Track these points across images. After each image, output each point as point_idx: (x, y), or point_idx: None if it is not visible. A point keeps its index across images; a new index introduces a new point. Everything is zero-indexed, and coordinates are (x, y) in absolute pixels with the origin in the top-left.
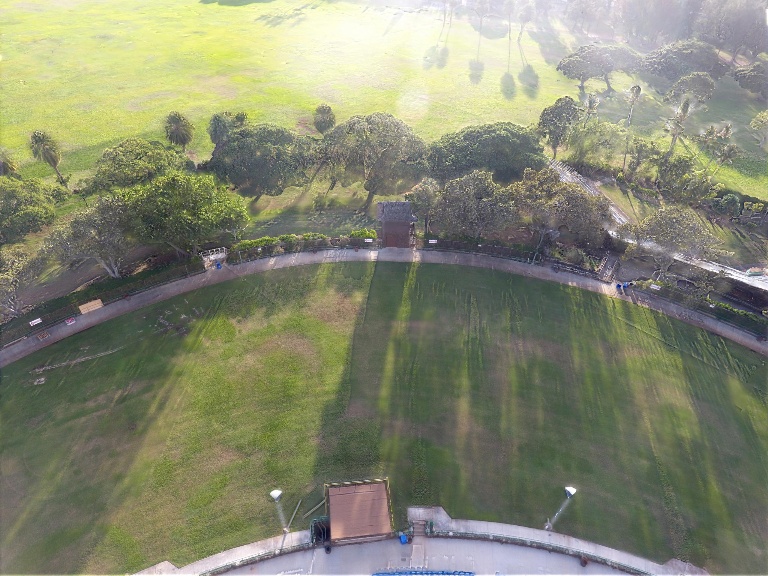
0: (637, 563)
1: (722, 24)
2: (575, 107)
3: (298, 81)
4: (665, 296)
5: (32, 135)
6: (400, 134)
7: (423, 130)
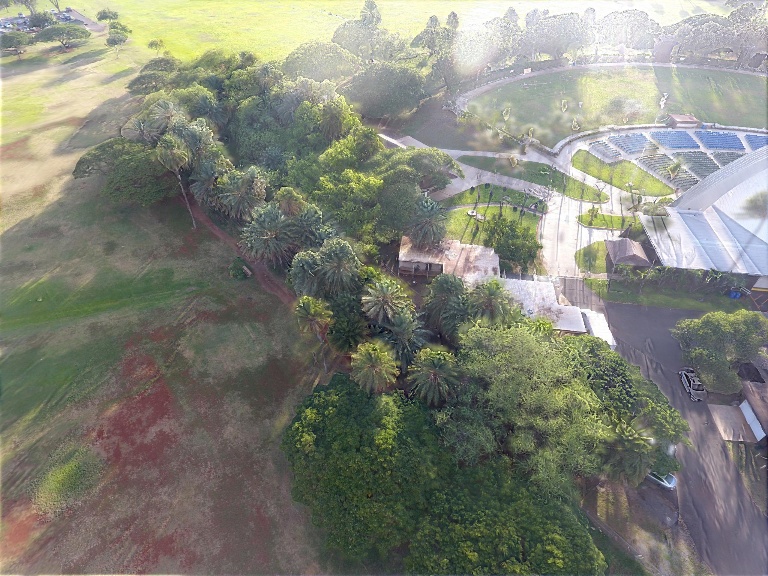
0: None
1: None
2: (755, 8)
3: None
4: None
5: (451, 13)
6: (646, 19)
7: None
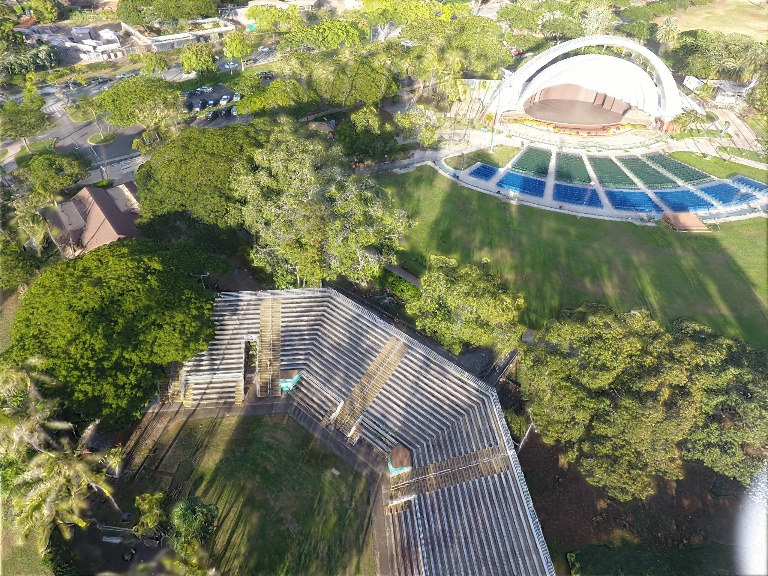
0: (535, 205)
1: None
2: None
3: None
4: None
5: None
6: None
7: None
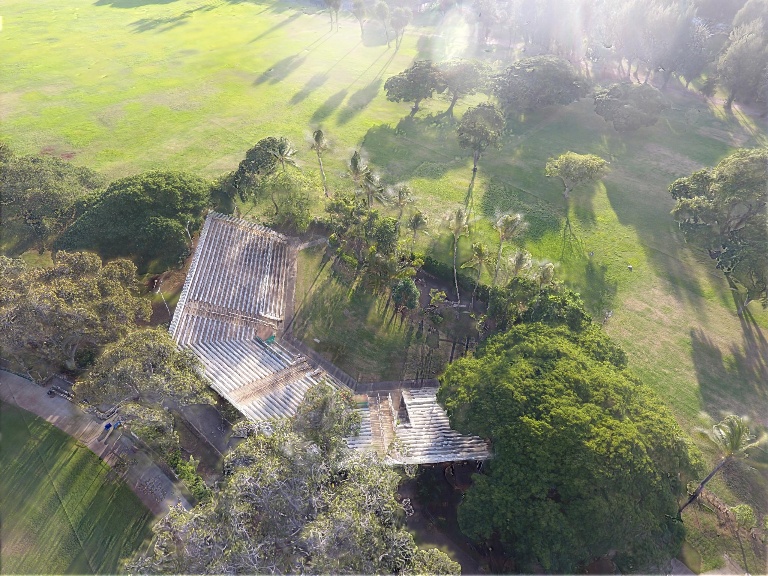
0: None
1: (612, 32)
2: (270, 152)
3: (91, 99)
4: (147, 450)
5: None
6: (30, 185)
7: (168, 165)
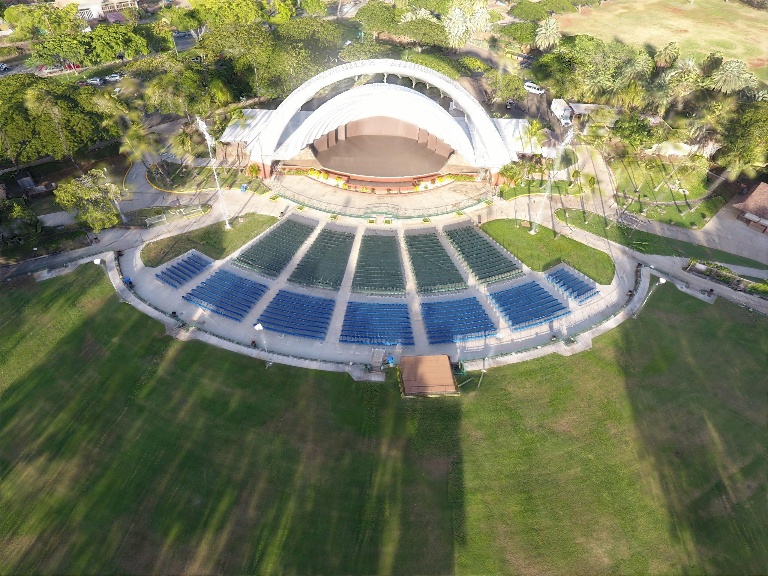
0: (214, 340)
1: None
2: None
3: None
4: None
5: None
6: None
7: None
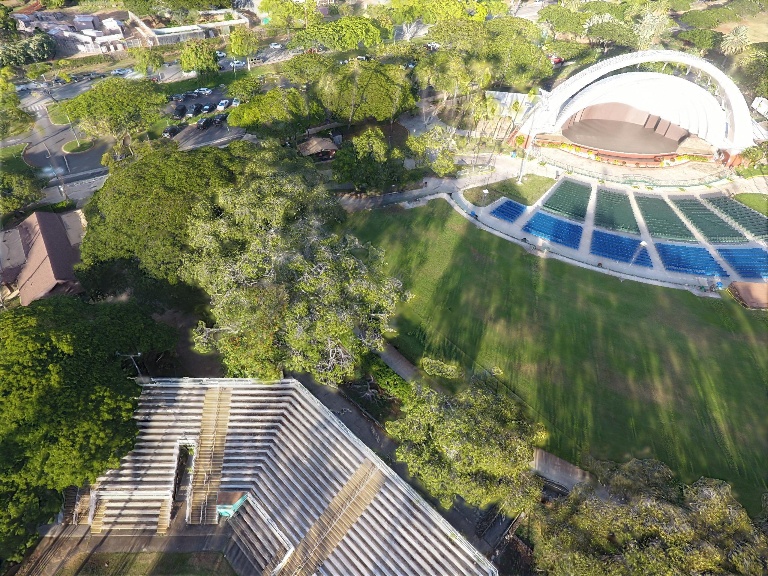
0: (568, 260)
1: None
2: None
3: None
4: None
5: None
6: None
7: None
